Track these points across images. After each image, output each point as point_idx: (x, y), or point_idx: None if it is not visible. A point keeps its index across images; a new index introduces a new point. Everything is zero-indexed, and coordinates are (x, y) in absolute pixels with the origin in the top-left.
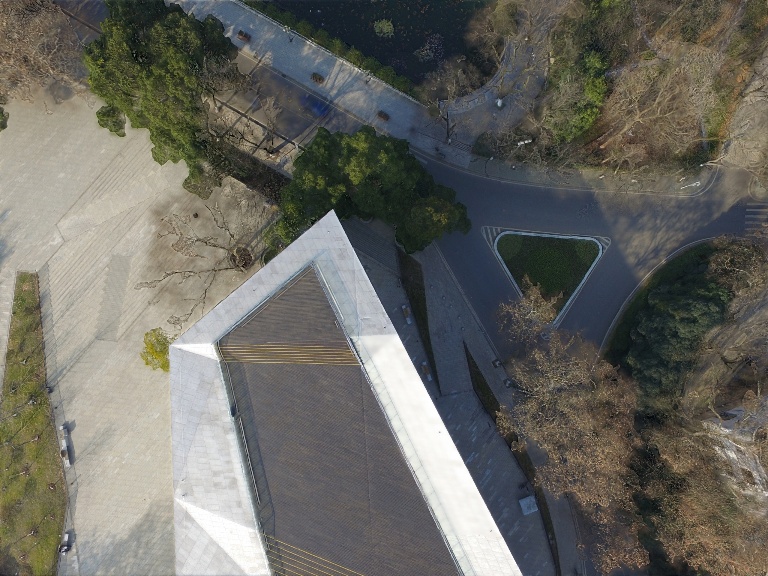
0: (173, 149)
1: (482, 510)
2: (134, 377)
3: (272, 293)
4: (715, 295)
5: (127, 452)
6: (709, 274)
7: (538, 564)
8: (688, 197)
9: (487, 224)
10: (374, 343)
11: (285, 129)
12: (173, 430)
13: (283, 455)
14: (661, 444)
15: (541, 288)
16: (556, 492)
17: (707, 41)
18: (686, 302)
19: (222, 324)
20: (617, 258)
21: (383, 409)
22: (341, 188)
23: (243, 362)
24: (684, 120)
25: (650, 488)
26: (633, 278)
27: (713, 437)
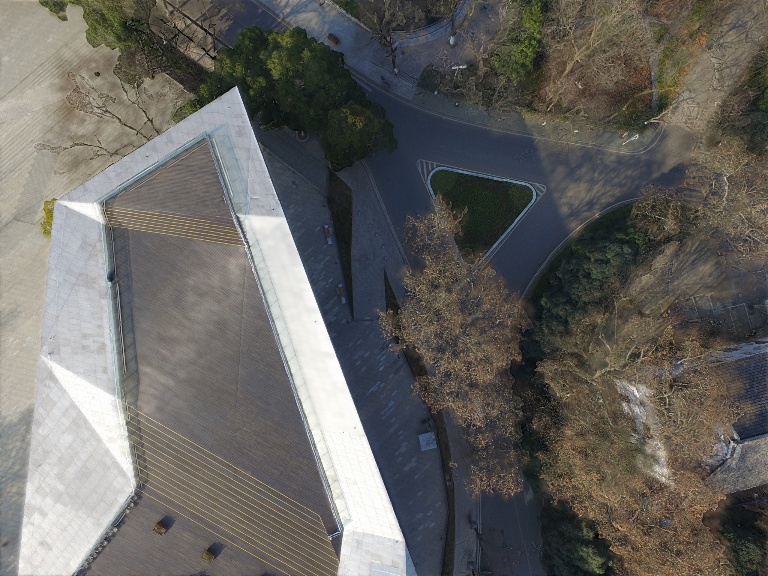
0: (103, 28)
1: (349, 406)
2: (46, 262)
3: (162, 159)
4: (632, 239)
5: (29, 335)
6: (630, 220)
7: (431, 503)
8: (629, 154)
9: (423, 158)
10: (261, 224)
11: (234, 41)
12: (48, 286)
13: (156, 327)
14: (546, 368)
15: (469, 227)
16: (434, 405)
17: (668, 4)
18: (603, 245)
19: (110, 186)
20: (550, 207)
21: (262, 292)
22: (260, 80)
23: (128, 228)
24: (609, 48)
25: (536, 419)
26: (564, 229)
27: (622, 392)
